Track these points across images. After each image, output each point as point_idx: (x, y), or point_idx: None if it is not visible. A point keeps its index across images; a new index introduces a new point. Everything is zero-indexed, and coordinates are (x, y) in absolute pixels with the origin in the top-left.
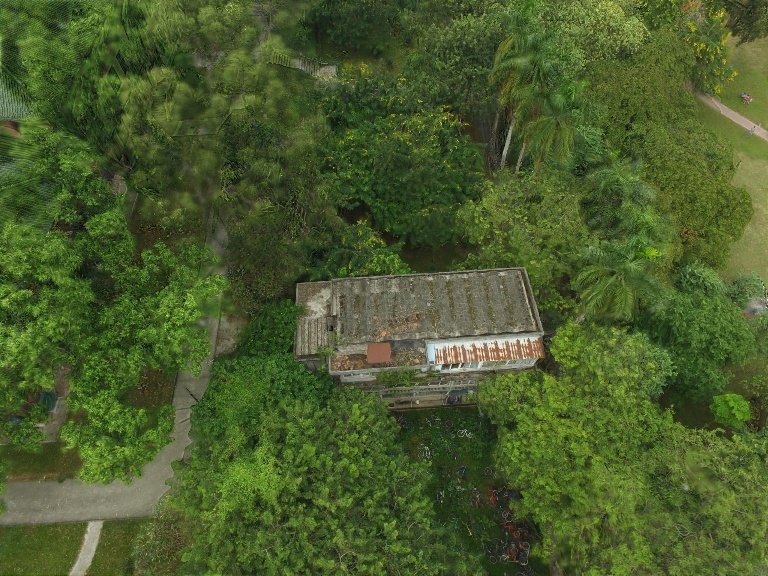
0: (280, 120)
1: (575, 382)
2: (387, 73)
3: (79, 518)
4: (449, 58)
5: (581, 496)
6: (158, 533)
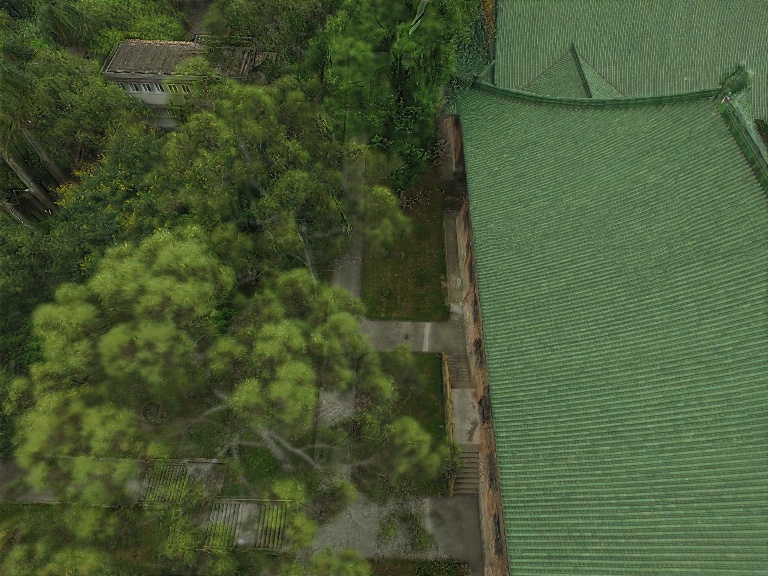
0: (285, 347)
1: (117, 26)
2: (79, 549)
3: (408, 54)
4: (0, 250)
5: (149, 1)
6: (347, 2)
